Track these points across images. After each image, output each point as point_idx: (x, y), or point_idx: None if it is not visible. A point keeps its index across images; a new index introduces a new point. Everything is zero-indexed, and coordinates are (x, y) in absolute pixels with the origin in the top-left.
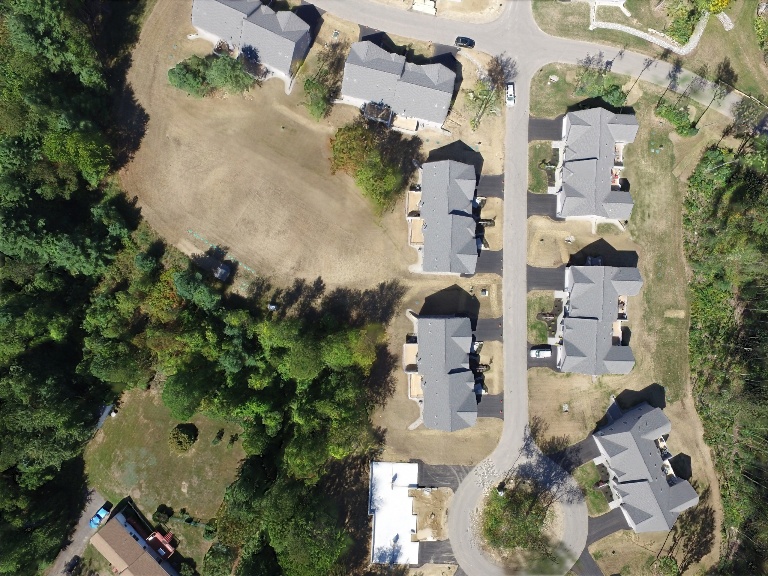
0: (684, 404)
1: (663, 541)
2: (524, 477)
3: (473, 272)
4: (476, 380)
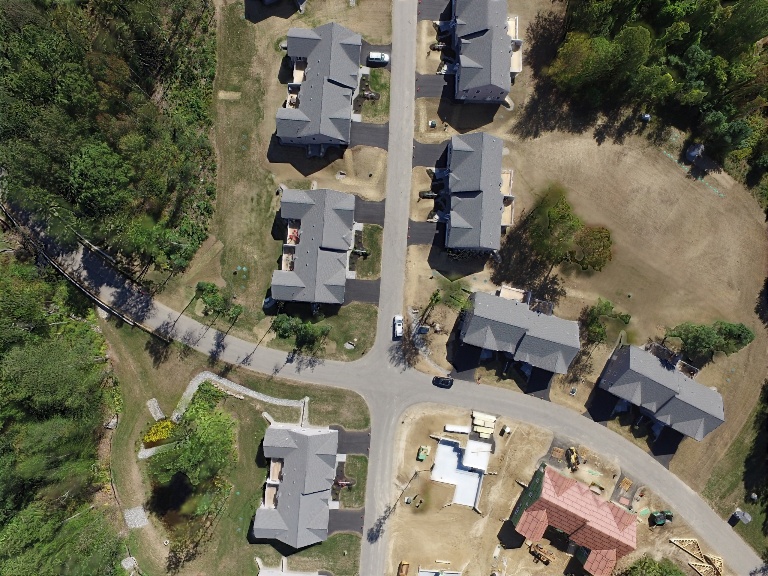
0: (224, 0)
1: None
2: None
3: (453, 137)
4: (445, 35)
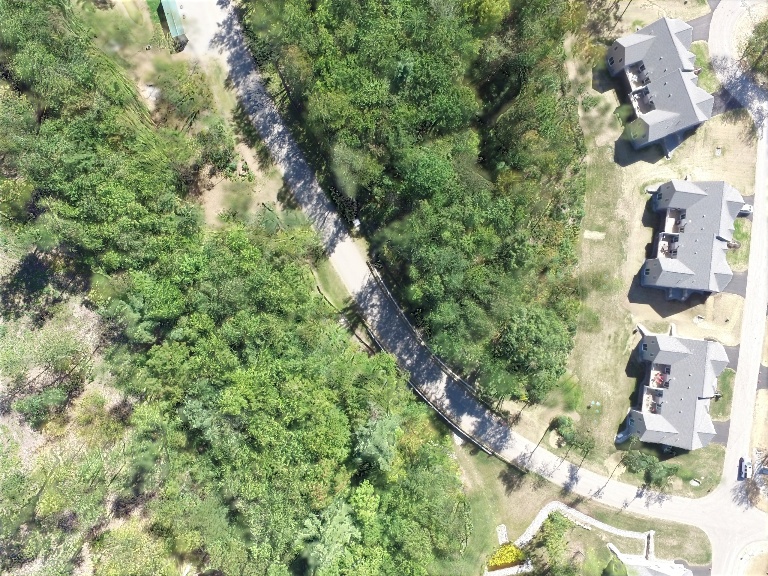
0: (594, 142)
1: (631, 7)
2: (765, 89)
3: None
4: None
